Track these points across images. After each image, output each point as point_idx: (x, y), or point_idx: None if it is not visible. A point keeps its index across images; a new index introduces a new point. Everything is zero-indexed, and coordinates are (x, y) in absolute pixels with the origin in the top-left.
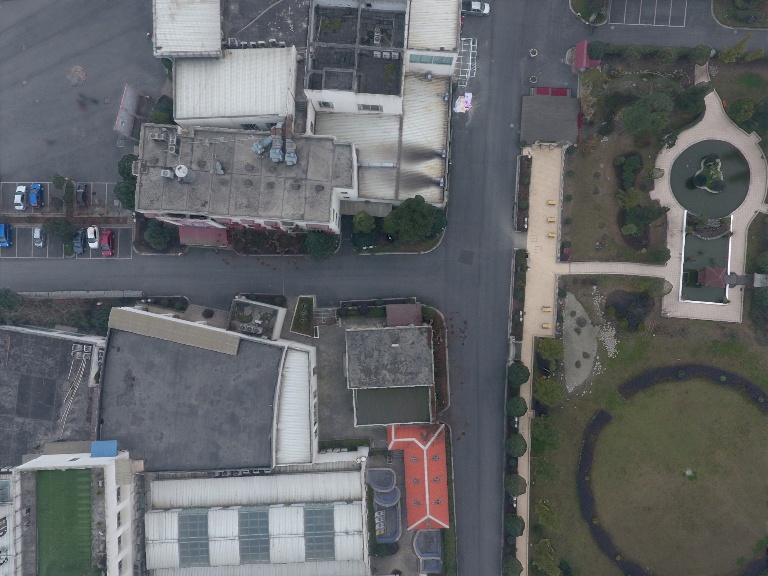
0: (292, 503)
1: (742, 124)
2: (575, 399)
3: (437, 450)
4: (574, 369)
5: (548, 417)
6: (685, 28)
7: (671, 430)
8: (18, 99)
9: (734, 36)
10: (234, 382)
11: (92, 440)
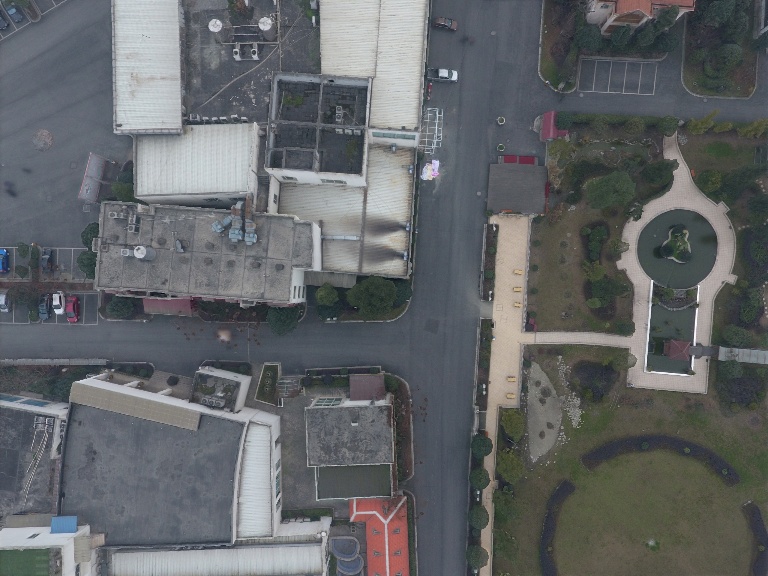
0: None
1: (710, 194)
2: (539, 469)
3: (399, 523)
4: (538, 439)
5: (511, 488)
6: (654, 96)
7: (635, 501)
8: None
9: (704, 105)
10: (195, 457)
11: (53, 513)
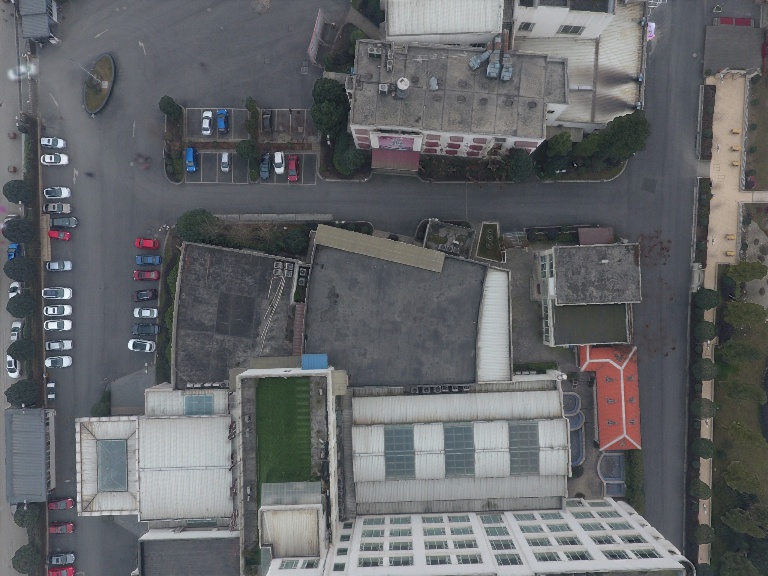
0: (493, 420)
1: None
2: (757, 327)
3: (631, 371)
4: (758, 296)
5: None
6: None
7: None
8: (203, 26)
9: None
10: (437, 299)
11: (296, 356)
